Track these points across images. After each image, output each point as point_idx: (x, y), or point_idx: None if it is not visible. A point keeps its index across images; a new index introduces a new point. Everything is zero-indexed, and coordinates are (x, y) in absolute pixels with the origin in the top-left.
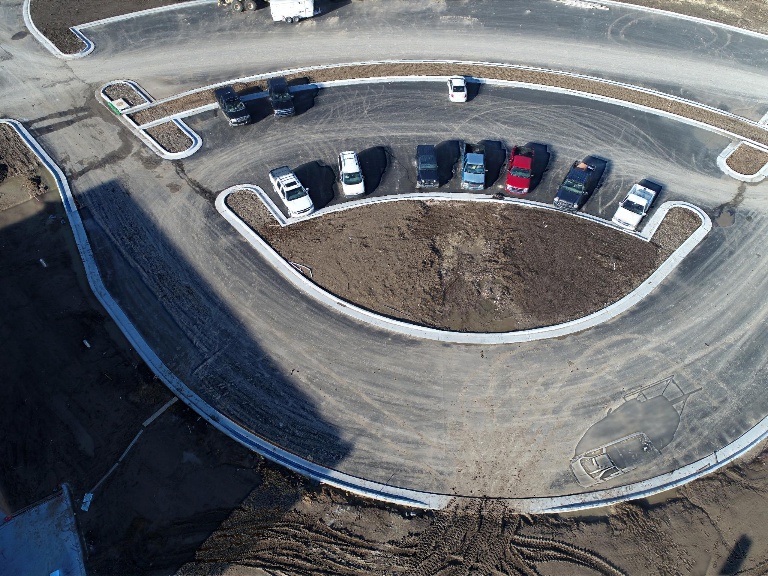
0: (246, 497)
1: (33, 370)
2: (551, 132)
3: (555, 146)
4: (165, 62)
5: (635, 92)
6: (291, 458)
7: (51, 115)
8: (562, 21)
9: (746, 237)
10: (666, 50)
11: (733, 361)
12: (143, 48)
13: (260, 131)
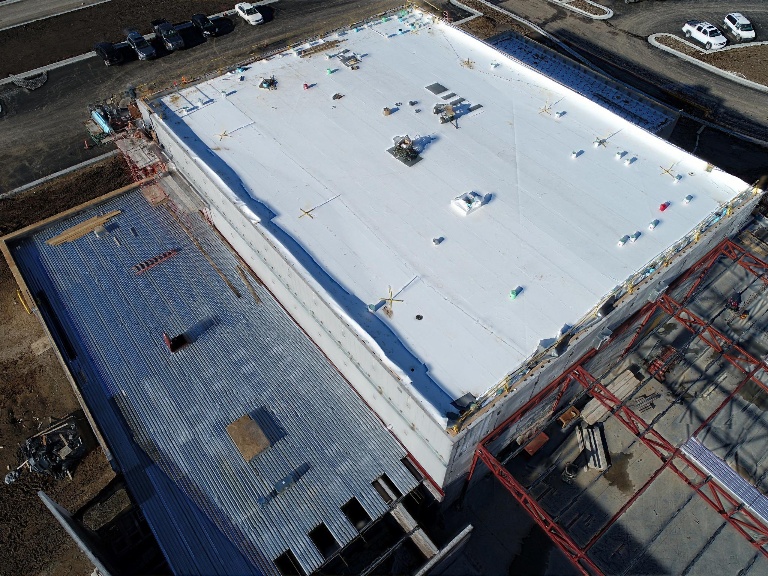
0: None
1: None
2: None
3: None
4: None
5: None
6: None
7: None
8: None
9: None
10: None
11: None
12: None
13: (648, 6)
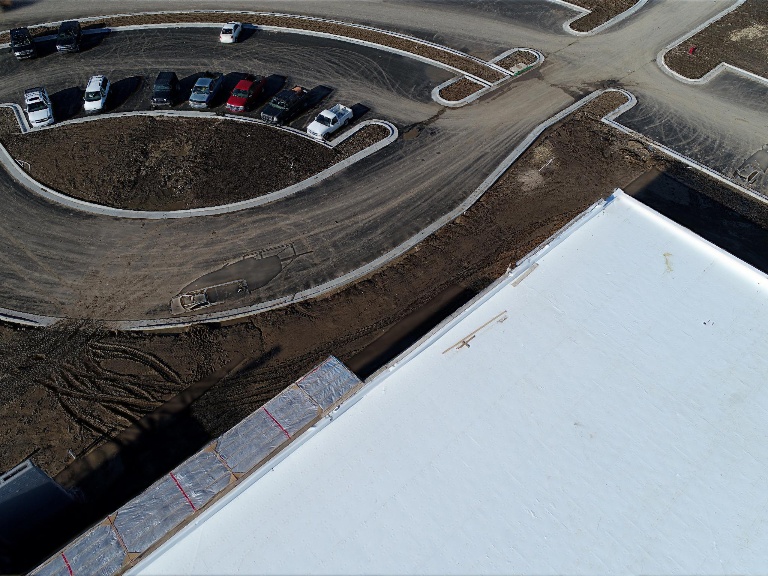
0: None
1: None
2: (298, 67)
3: (294, 77)
4: None
5: (392, 37)
6: None
7: None
8: None
9: (421, 147)
10: (440, 5)
11: (351, 233)
12: None
13: (42, 64)
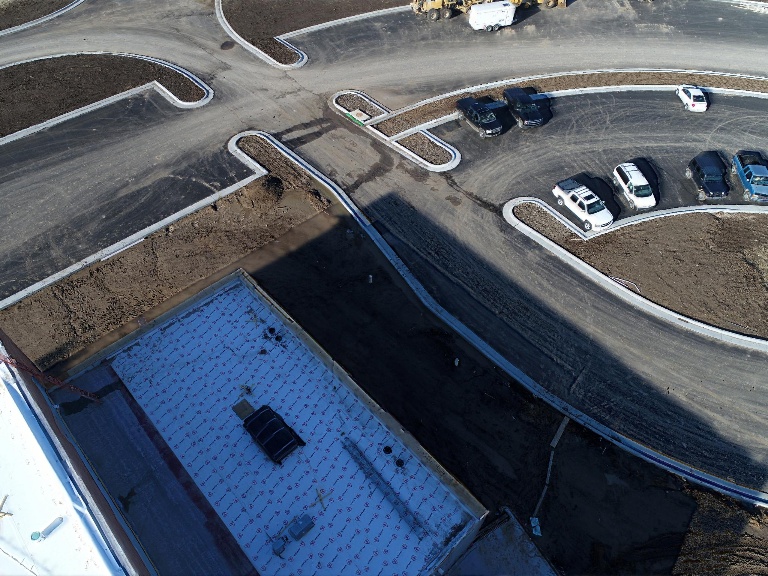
0: (691, 520)
1: (413, 389)
2: None
3: None
4: (383, 72)
5: None
6: (713, 479)
7: (296, 127)
8: (759, 28)
9: None
10: None
11: None
12: (355, 58)
13: (512, 142)
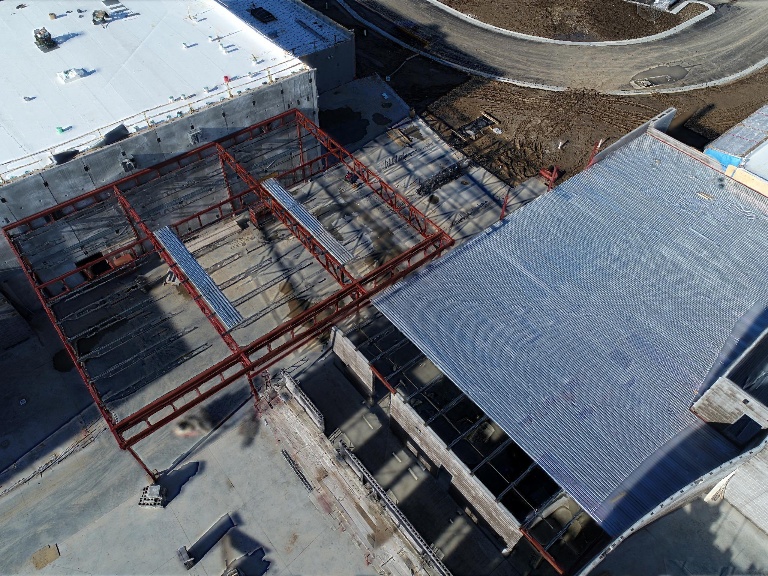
0: (465, 82)
1: None
2: None
3: None
4: None
5: None
6: (484, 74)
7: None
8: None
9: (736, 16)
10: None
11: (720, 57)
12: None
13: None
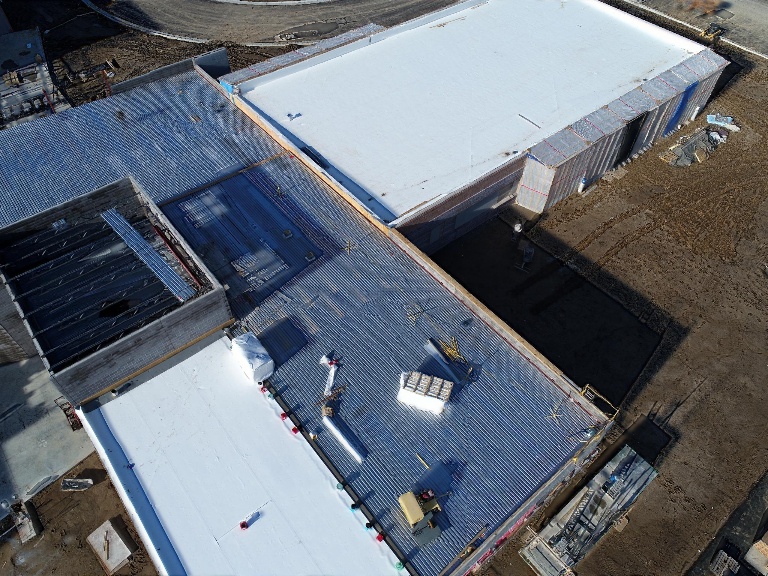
0: (118, 35)
1: (29, 0)
2: None
3: None
4: None
5: None
6: (143, 28)
7: None
8: None
9: None
10: None
11: (381, 15)
12: None
13: None
